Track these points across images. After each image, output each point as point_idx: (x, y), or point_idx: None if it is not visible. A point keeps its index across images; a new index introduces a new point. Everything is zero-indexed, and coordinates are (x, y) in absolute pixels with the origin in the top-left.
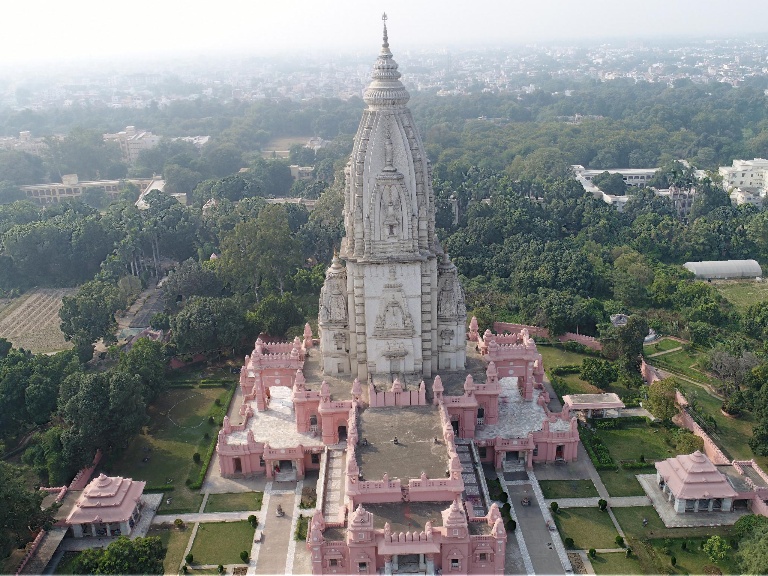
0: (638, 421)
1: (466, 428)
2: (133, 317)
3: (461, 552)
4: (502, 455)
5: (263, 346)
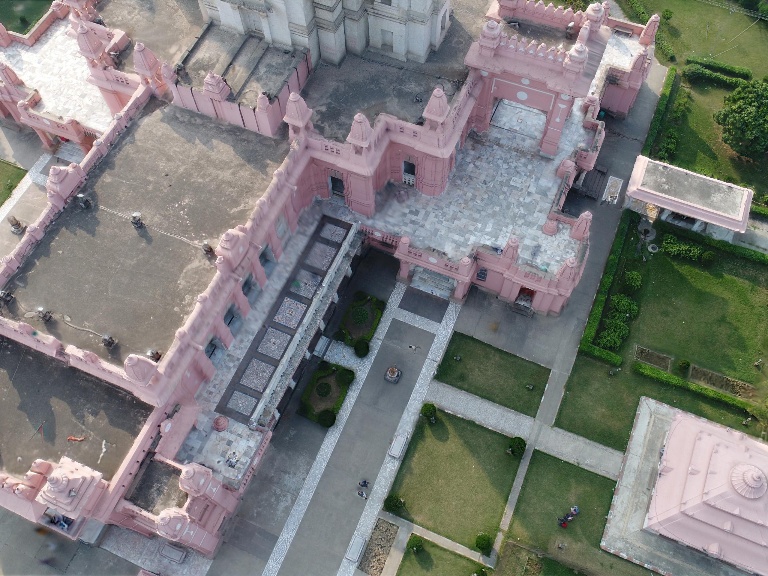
0: (757, 262)
1: (353, 198)
2: None
3: None
4: None
5: None
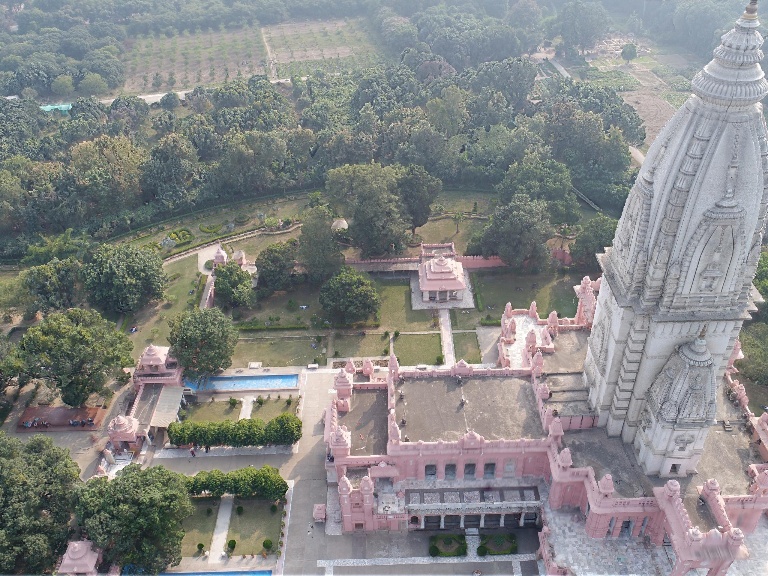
0: None
1: (550, 490)
2: None
3: None
4: None
5: None
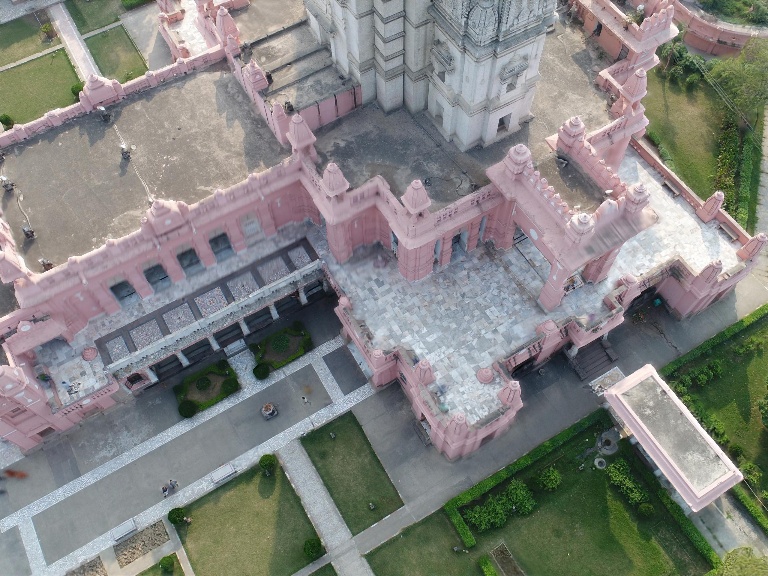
0: (699, 552)
1: (328, 237)
2: None
3: None
4: None
5: None
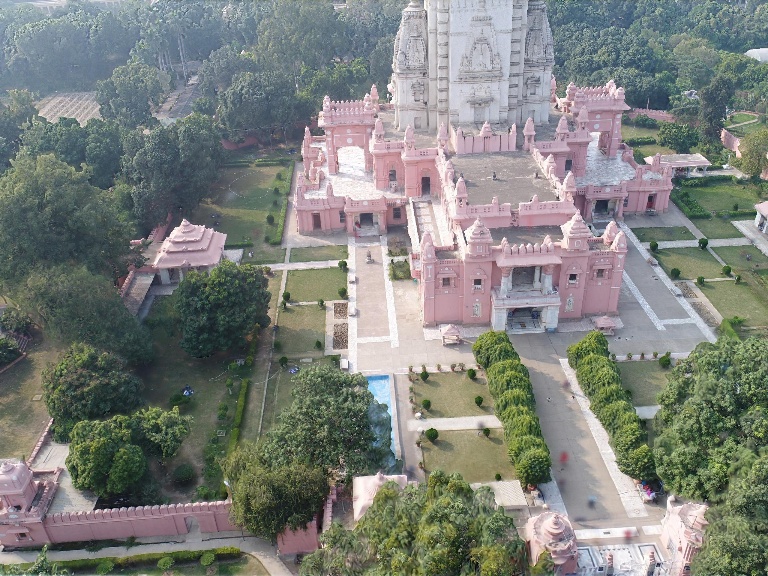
0: (724, 180)
1: None
2: (168, 112)
3: (580, 267)
4: (592, 205)
5: (331, 104)
